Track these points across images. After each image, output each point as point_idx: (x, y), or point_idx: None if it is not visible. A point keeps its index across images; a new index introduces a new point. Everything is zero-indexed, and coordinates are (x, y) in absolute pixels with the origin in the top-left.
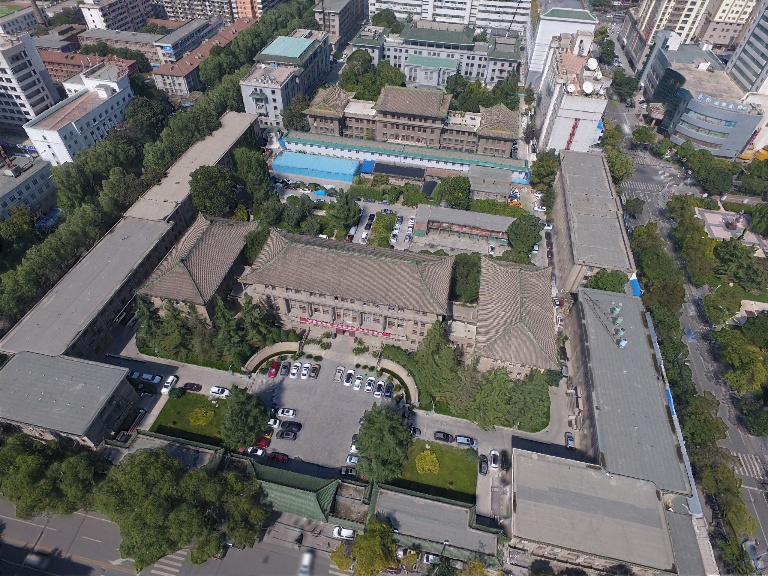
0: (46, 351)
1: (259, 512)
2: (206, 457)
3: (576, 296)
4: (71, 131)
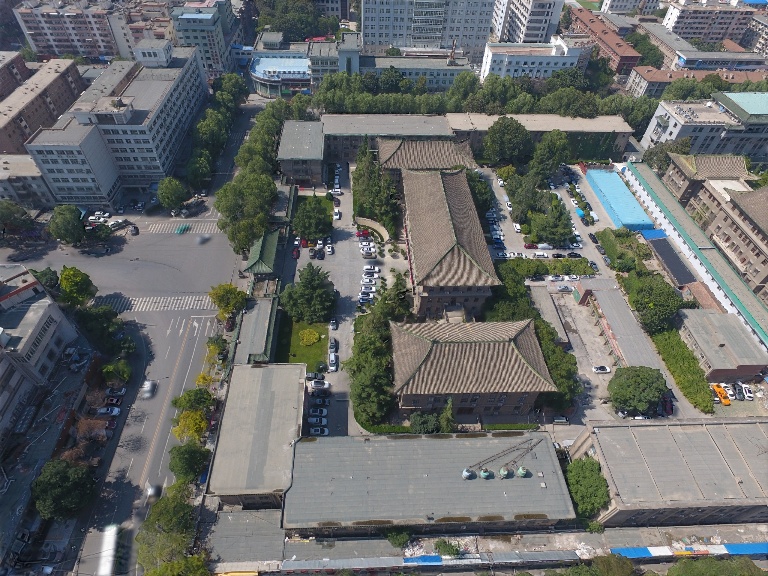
0: (325, 129)
1: (243, 236)
2: (282, 214)
3: (566, 463)
4: (503, 60)
